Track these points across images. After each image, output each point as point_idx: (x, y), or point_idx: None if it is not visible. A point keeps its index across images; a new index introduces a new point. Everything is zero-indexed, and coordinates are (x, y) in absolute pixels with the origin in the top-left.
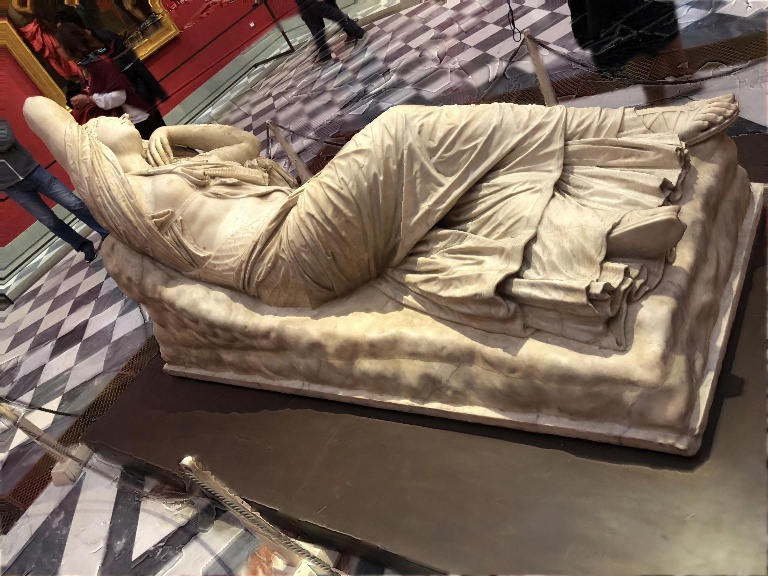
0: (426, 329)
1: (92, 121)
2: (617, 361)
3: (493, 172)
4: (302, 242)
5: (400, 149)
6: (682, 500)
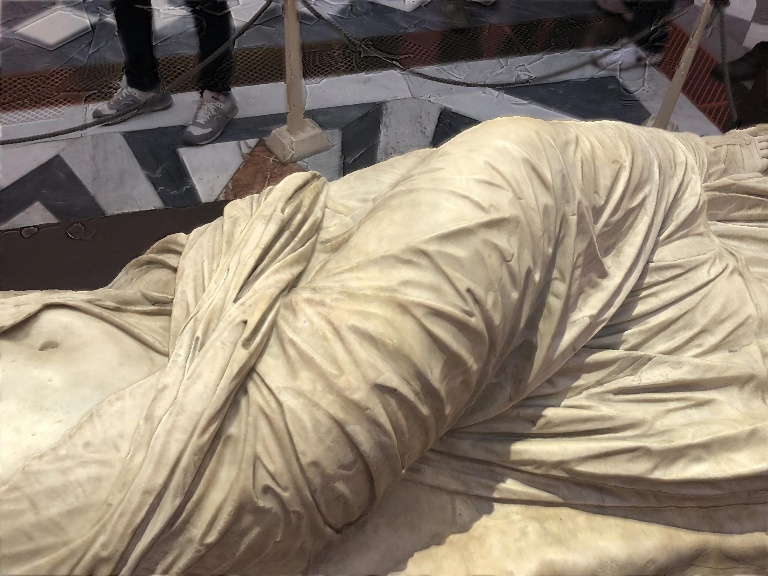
0: (595, 537)
1: None
2: None
3: None
4: (345, 457)
5: (559, 213)
6: None
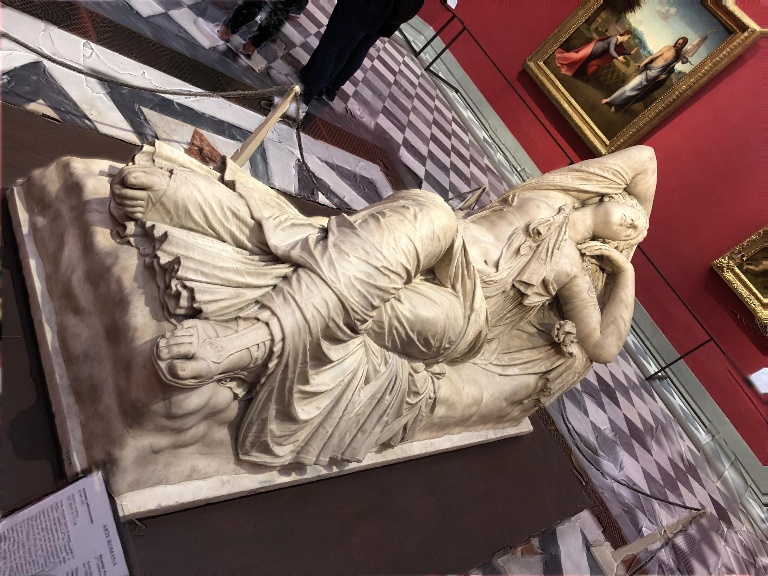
0: None
1: (640, 207)
2: (101, 162)
3: (325, 234)
4: None
5: None
6: (1, 169)
